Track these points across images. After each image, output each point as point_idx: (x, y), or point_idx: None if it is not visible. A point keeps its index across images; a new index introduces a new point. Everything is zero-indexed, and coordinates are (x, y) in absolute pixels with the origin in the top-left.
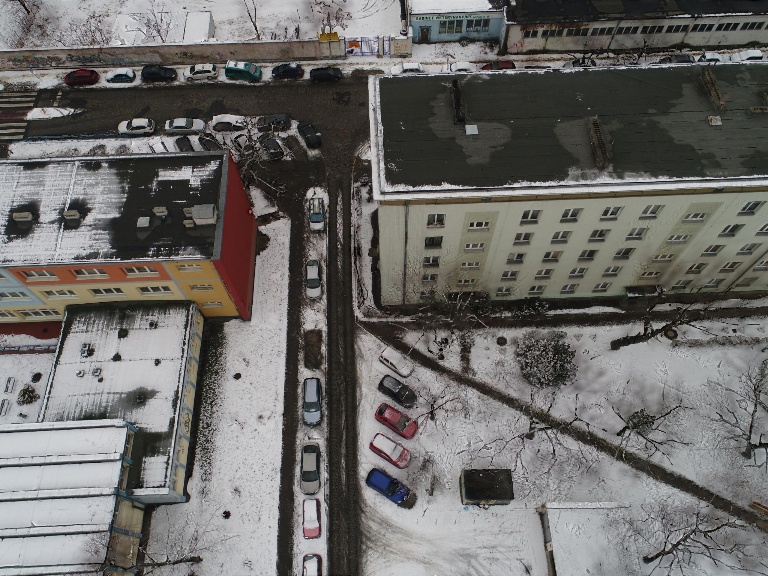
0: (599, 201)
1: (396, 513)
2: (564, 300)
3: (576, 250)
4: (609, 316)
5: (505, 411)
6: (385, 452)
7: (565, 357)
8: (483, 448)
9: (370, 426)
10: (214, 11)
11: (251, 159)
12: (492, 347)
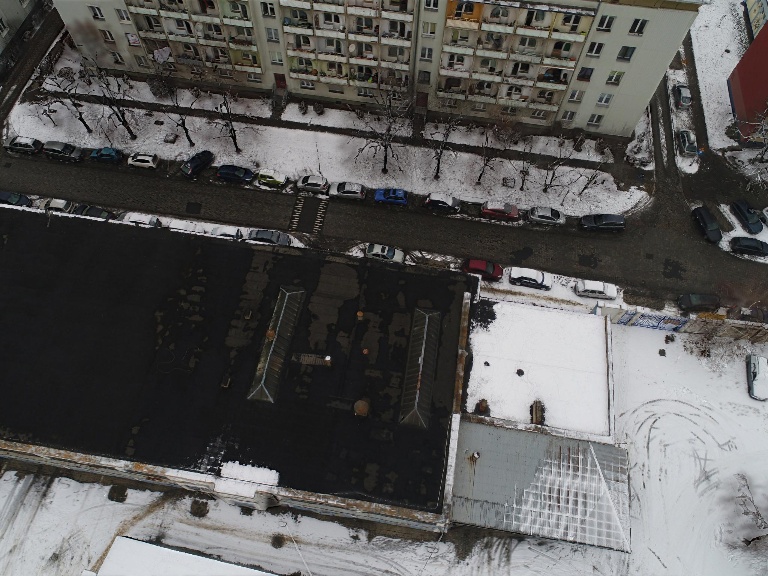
0: None
1: None
2: None
3: None
4: None
5: None
6: None
7: None
8: None
9: None
10: None
11: None
12: None
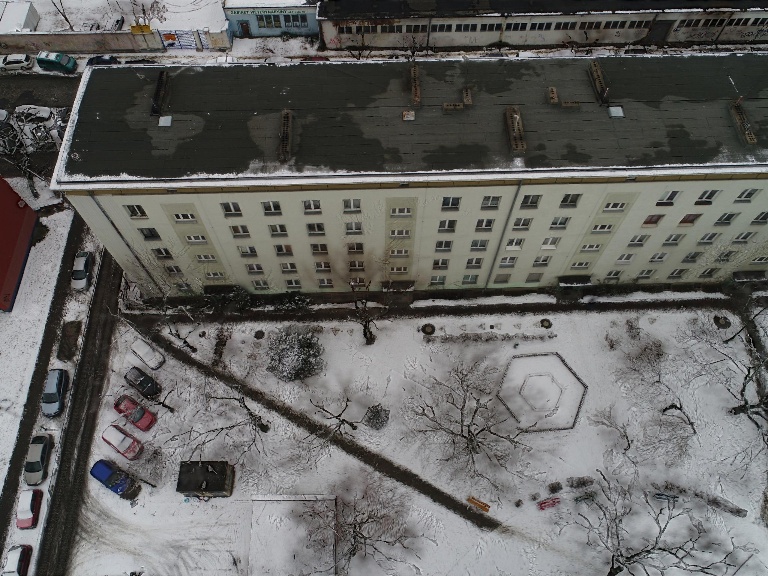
0: (289, 194)
1: (117, 504)
2: (329, 295)
3: (303, 244)
4: (371, 311)
5: (247, 404)
6: (112, 443)
7: (308, 351)
8: (170, 439)
9: (110, 418)
10: (43, 2)
11: (32, 150)
12: (248, 340)
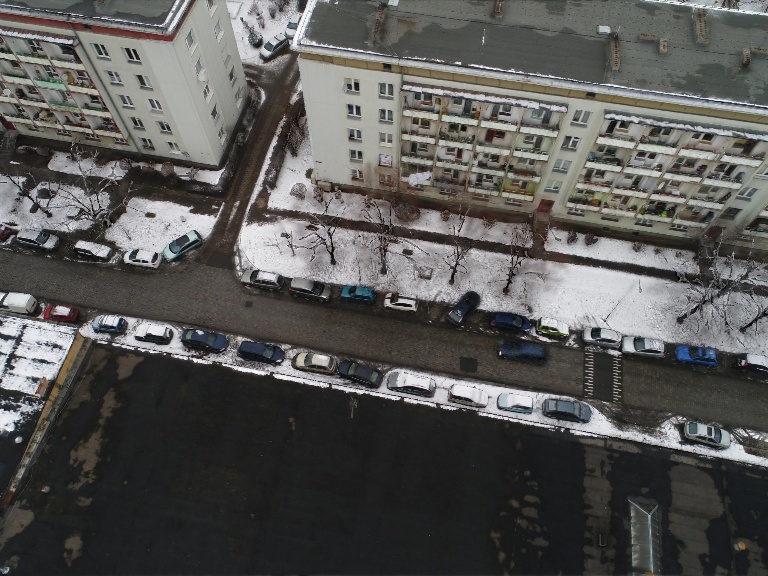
0: None
1: None
2: None
3: None
4: None
5: None
6: None
7: None
8: None
9: None
10: None
11: None
12: None
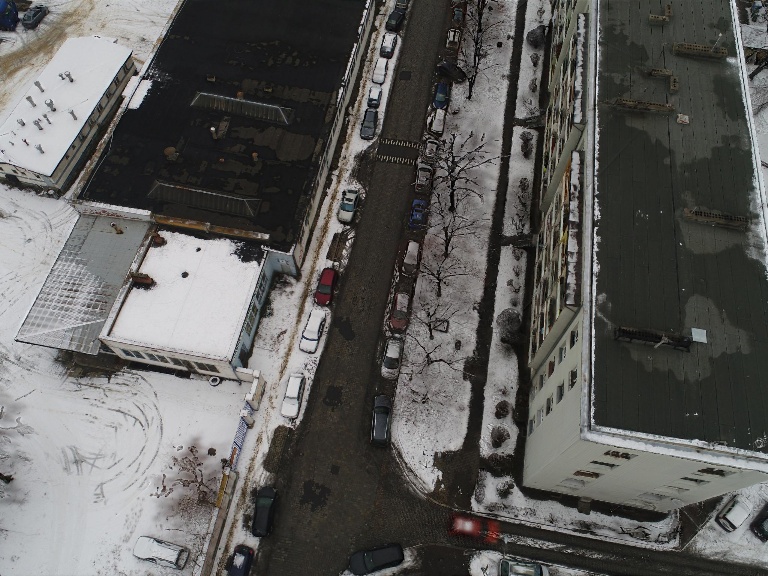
0: None
1: None
2: None
3: None
4: None
5: None
6: None
7: None
8: None
9: None
10: None
11: None
12: None
